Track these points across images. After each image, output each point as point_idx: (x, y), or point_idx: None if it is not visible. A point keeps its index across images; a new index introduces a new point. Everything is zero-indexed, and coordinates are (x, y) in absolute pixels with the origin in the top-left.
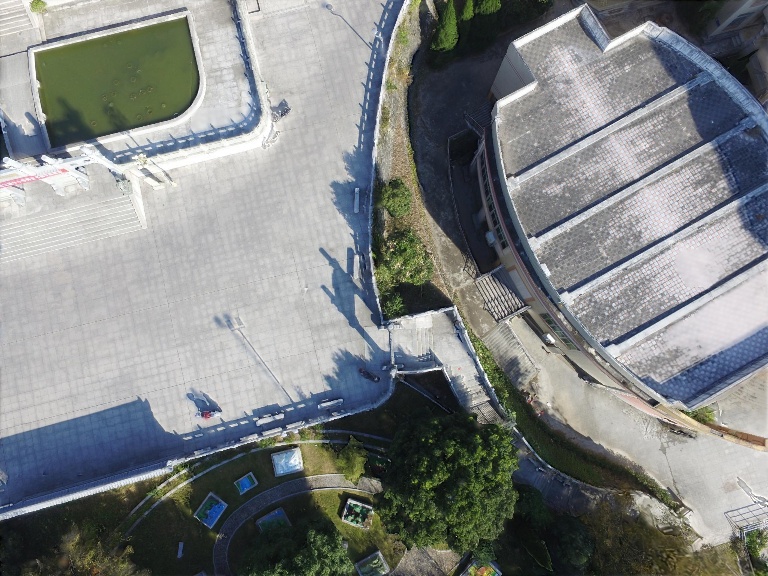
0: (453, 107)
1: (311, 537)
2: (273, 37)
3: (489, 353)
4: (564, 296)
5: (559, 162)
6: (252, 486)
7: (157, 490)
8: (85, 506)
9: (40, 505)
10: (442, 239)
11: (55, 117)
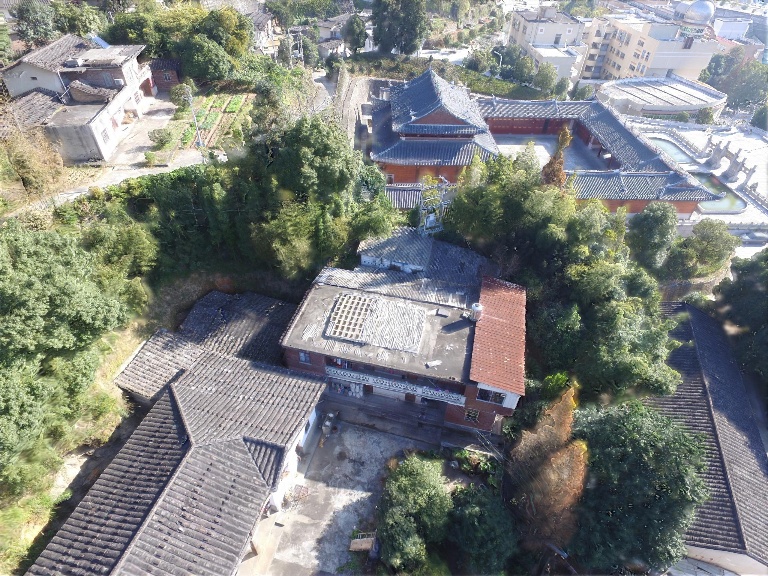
0: None
1: None
2: None
3: None
4: None
5: None
6: None
7: None
8: None
9: None
10: None
11: None
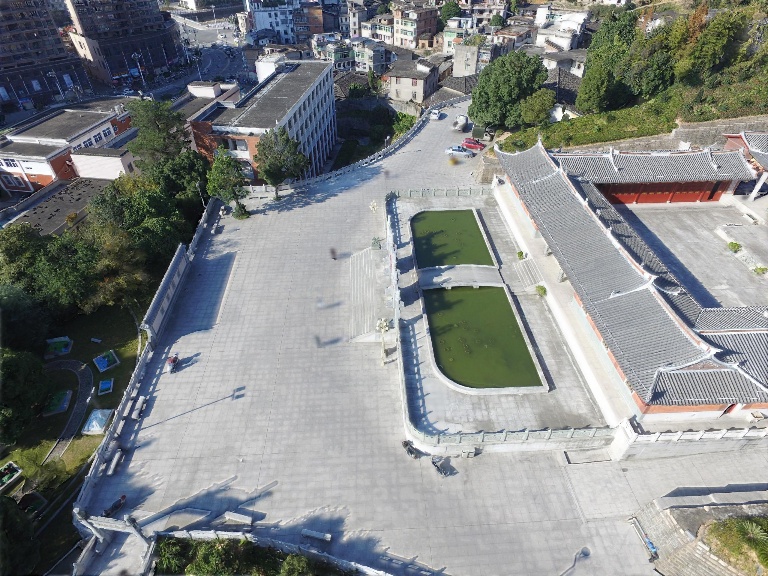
0: None
1: (5, 411)
2: (537, 473)
3: None
4: None
5: None
6: (100, 390)
7: None
8: None
9: None
10: None
11: (449, 294)
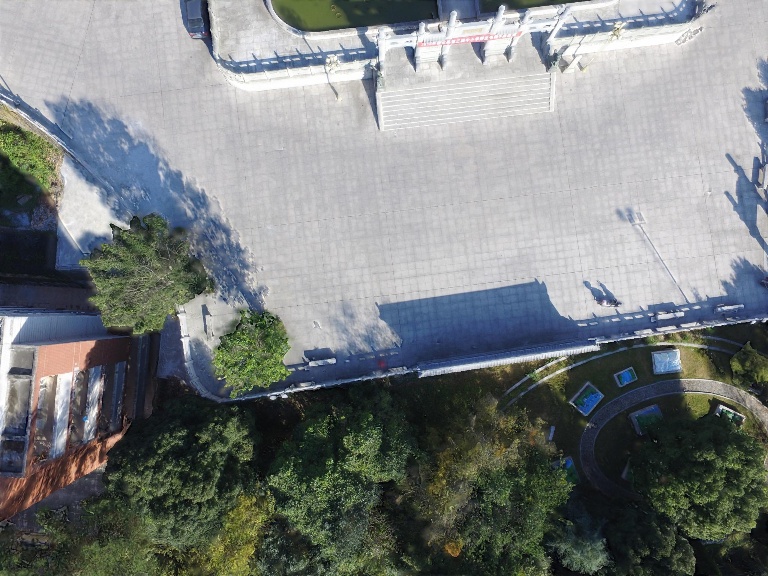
0: None
1: (736, 428)
2: None
3: None
4: None
5: None
6: (632, 380)
7: (535, 373)
8: (458, 381)
9: (469, 366)
10: None
11: None
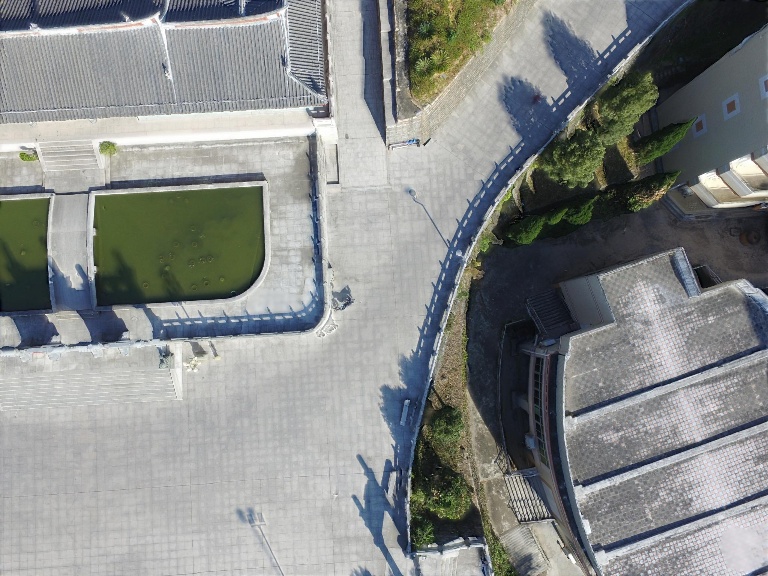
0: (516, 288)
1: None
2: (348, 215)
3: (505, 556)
4: (600, 555)
5: (621, 408)
6: None
7: None
8: None
9: None
10: (479, 425)
11: (106, 270)
